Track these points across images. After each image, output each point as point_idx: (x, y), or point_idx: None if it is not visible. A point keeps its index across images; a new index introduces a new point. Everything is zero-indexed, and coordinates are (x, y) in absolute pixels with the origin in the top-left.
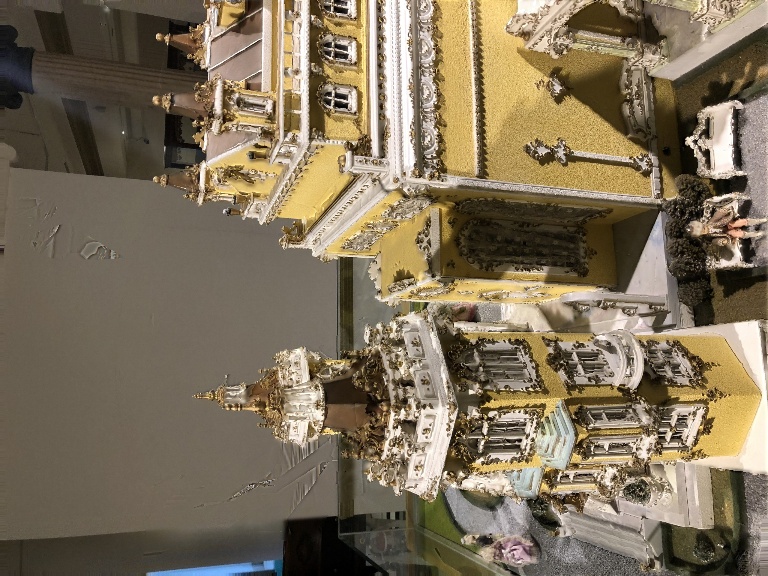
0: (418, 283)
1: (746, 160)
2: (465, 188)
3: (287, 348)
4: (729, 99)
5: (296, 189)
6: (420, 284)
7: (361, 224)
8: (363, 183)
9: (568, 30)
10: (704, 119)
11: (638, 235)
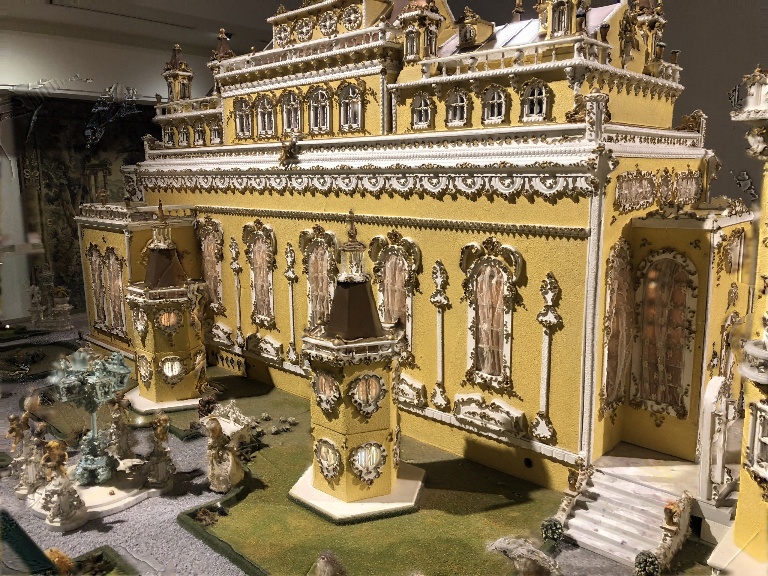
0: (750, 212)
1: None
2: None
3: (734, 104)
4: None
5: (625, 96)
6: (748, 217)
7: (659, 167)
8: (697, 133)
9: None
10: None
11: None
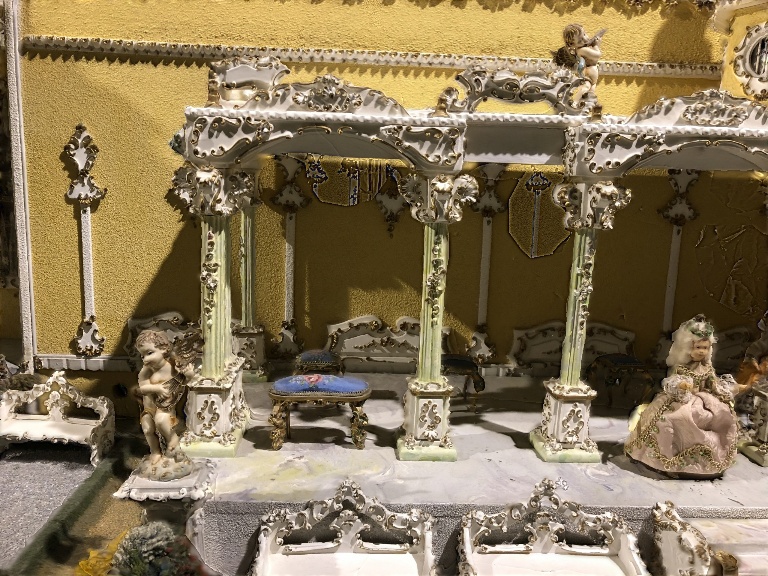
0: None
1: (7, 465)
2: (4, 17)
3: None
4: (119, 450)
5: None
6: None
7: None
8: None
9: (288, 224)
10: (95, 408)
11: (19, 352)
